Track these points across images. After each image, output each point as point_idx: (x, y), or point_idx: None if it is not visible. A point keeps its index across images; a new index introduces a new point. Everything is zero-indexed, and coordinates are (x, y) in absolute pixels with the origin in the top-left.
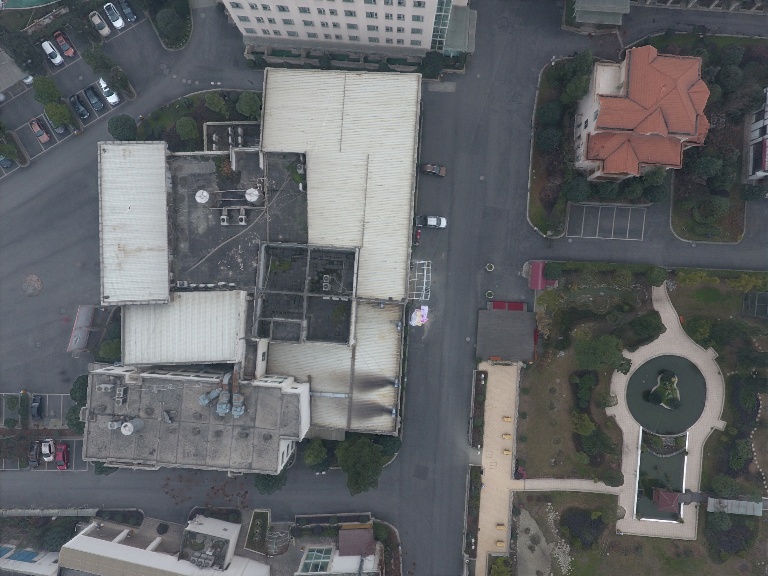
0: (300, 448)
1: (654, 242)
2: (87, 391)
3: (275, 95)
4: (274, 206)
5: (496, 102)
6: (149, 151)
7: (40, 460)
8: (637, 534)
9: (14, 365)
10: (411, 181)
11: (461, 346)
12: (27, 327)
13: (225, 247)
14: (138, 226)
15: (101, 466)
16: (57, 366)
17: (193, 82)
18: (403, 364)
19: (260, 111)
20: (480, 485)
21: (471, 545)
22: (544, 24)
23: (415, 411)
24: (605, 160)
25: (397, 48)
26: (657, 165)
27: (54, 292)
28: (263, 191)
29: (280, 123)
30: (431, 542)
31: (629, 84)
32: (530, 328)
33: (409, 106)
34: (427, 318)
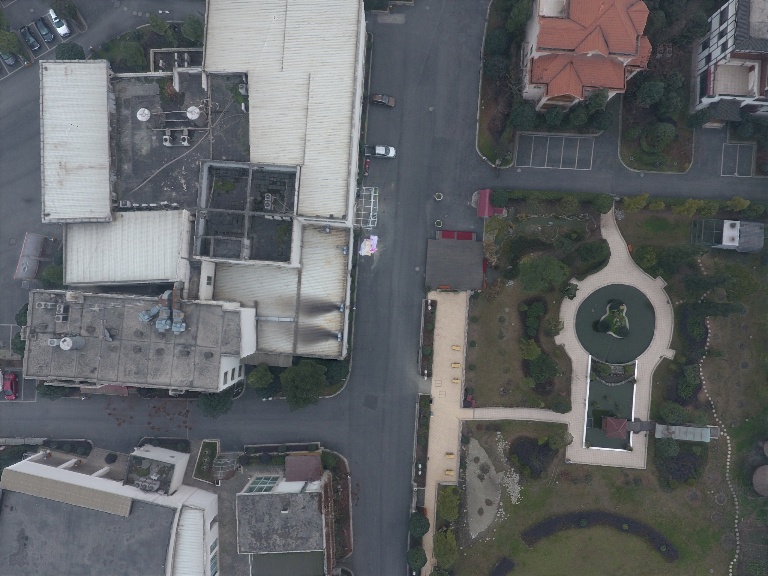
0: None
1: (603, 172)
2: (28, 309)
3: (218, 15)
4: (218, 127)
5: (445, 34)
6: (91, 70)
7: None
8: (586, 463)
9: None
10: (352, 99)
11: (410, 276)
12: None
13: (169, 168)
14: (80, 144)
15: (45, 389)
16: (6, 297)
17: (144, 14)
18: (352, 293)
19: None
20: (429, 414)
21: (420, 474)
22: None
23: (364, 340)
24: (549, 84)
25: None
26: (601, 89)
27: (4, 223)
28: (206, 112)
29: (222, 43)
30: (380, 472)
31: (570, 5)
32: (479, 257)
33: (350, 25)
34: (376, 248)
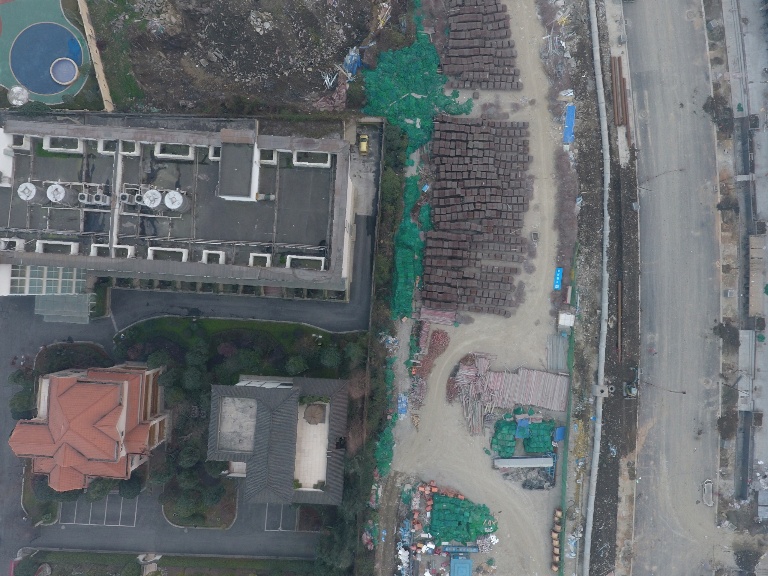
0: None
1: (146, 528)
2: None
3: None
4: None
5: None
6: None
7: None
8: None
9: None
10: None
11: None
12: None
13: None
14: None
15: None
16: None
17: None
18: None
19: None
20: None
21: None
22: None
23: None
24: (50, 473)
25: None
26: (103, 477)
27: None
28: None
29: None
30: None
31: (49, 411)
32: None
33: None
34: None
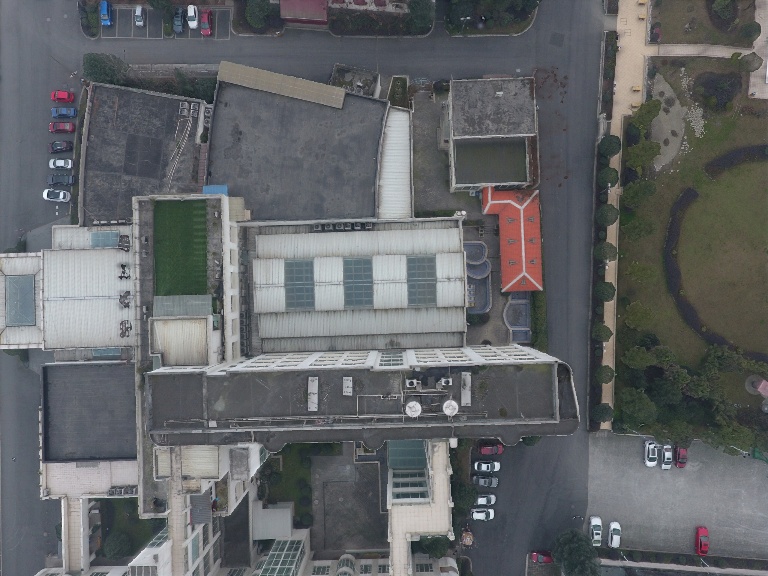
0: (438, 16)
1: None
2: None
3: None
4: None
5: None
6: None
7: (184, 28)
8: None
9: None
10: None
11: None
12: None
13: None
14: None
15: None
16: None
17: None
18: None
19: None
20: (616, 47)
21: (607, 106)
22: None
23: None
24: None
25: None
26: None
27: None
28: None
29: None
30: (567, 106)
31: None
32: None
33: None
34: None
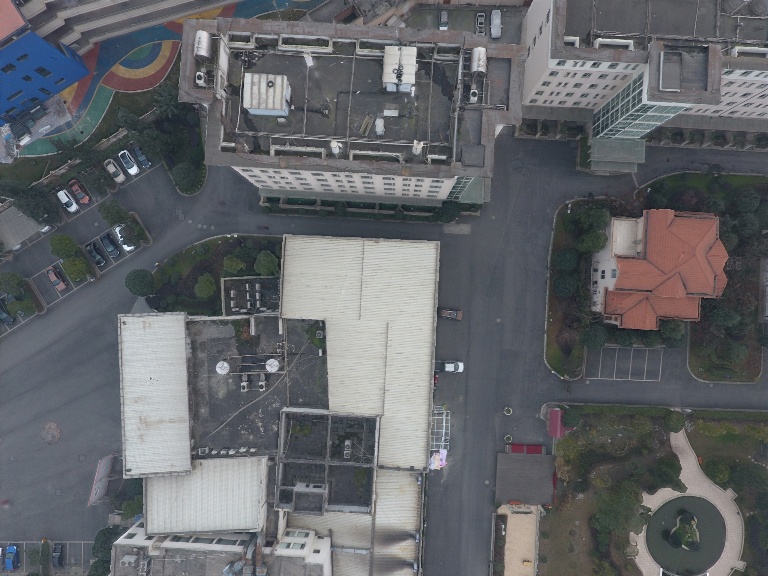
0: None
1: (671, 383)
2: (111, 563)
3: (294, 262)
4: (294, 369)
5: (512, 244)
6: (169, 322)
7: None
8: None
9: (34, 513)
10: (431, 349)
11: (480, 489)
12: (46, 475)
13: (245, 411)
14: (159, 398)
15: None
16: (77, 514)
17: (209, 227)
18: (423, 509)
19: (277, 267)
20: None
21: None
22: (558, 165)
23: (435, 555)
24: (623, 315)
25: (413, 198)
26: (675, 319)
27: (73, 439)
28: (283, 355)
29: (299, 290)
30: None
31: (647, 245)
32: (549, 471)
33: (428, 274)
34: (446, 462)
